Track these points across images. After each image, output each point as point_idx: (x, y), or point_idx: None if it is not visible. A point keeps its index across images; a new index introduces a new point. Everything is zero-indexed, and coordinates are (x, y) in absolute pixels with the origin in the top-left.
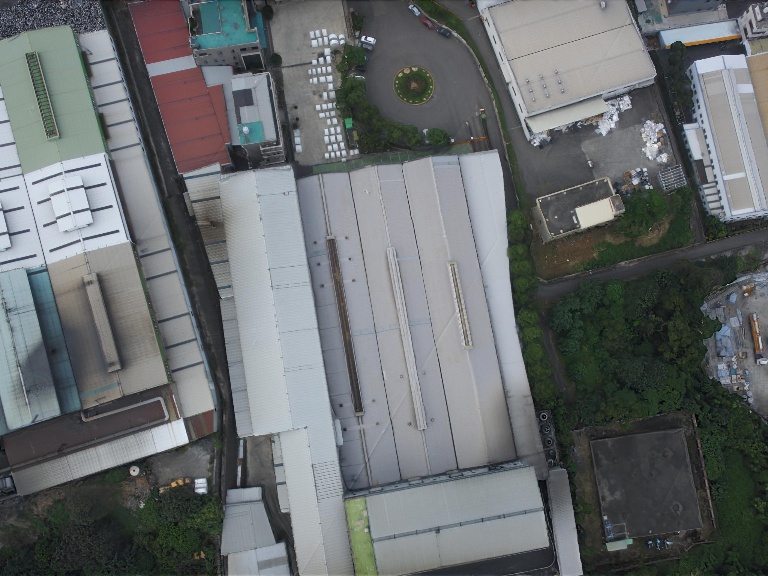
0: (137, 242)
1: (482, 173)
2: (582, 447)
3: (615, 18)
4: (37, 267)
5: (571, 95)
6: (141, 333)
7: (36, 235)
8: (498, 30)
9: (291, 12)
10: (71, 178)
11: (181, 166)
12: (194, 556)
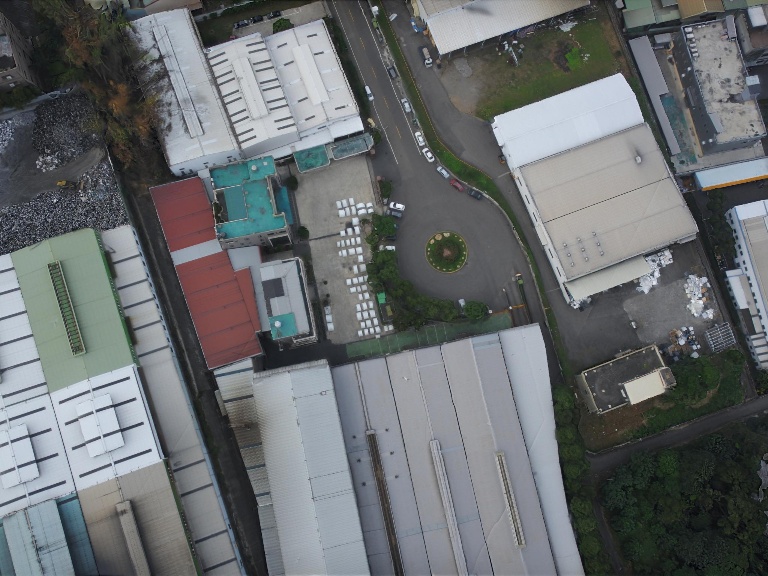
0: (170, 455)
1: (524, 349)
2: None
3: (651, 172)
4: (67, 495)
5: (611, 257)
6: (179, 563)
7: (65, 459)
8: (531, 192)
9: (316, 181)
10: (100, 398)
11: (211, 360)
12: None
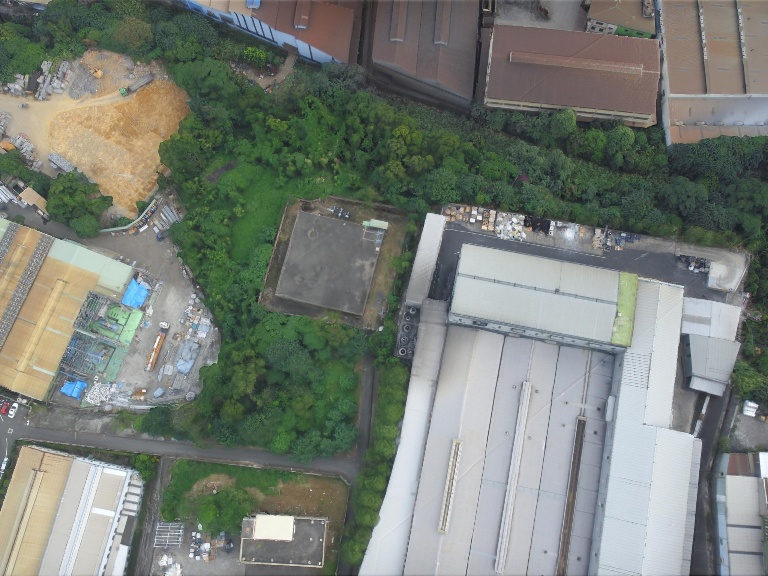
0: None
1: None
2: (371, 313)
3: None
4: None
5: None
6: None
7: None
8: None
9: None
10: None
11: None
12: (761, 351)
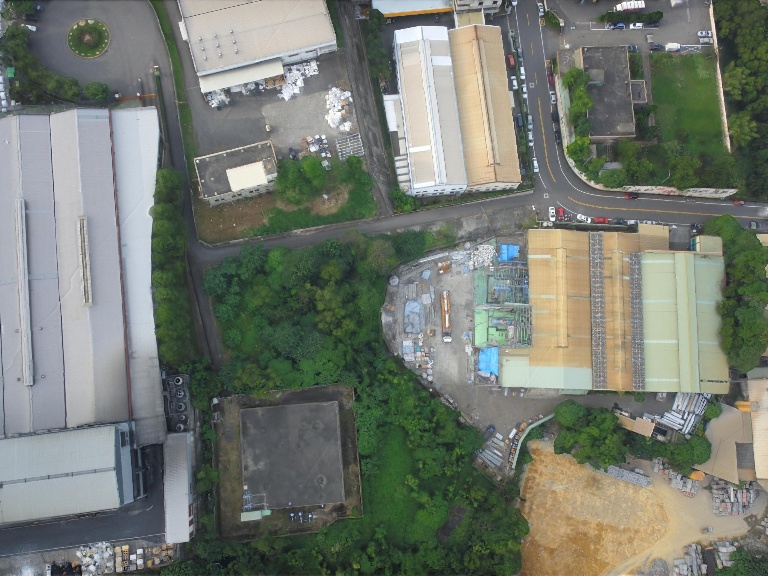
0: None
1: (136, 129)
2: (232, 415)
3: None
4: None
5: (246, 56)
6: None
7: None
8: None
9: None
10: None
11: None
12: None
